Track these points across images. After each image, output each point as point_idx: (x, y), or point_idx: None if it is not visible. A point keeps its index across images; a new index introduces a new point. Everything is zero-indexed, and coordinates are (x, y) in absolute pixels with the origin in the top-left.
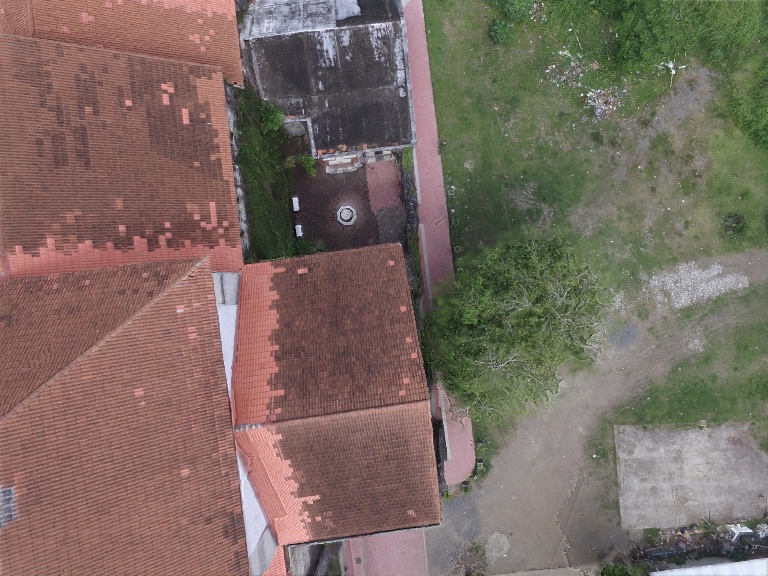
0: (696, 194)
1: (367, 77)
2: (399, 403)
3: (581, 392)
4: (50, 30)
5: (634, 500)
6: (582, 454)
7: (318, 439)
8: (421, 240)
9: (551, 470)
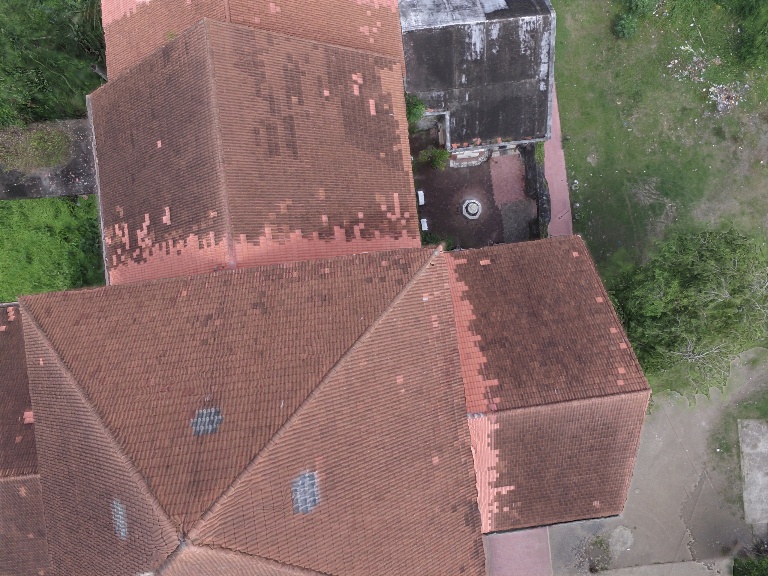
0: None
1: (510, 70)
2: (621, 392)
3: None
4: (244, 20)
5: (758, 494)
6: (705, 448)
7: (533, 428)
8: None
9: (674, 464)
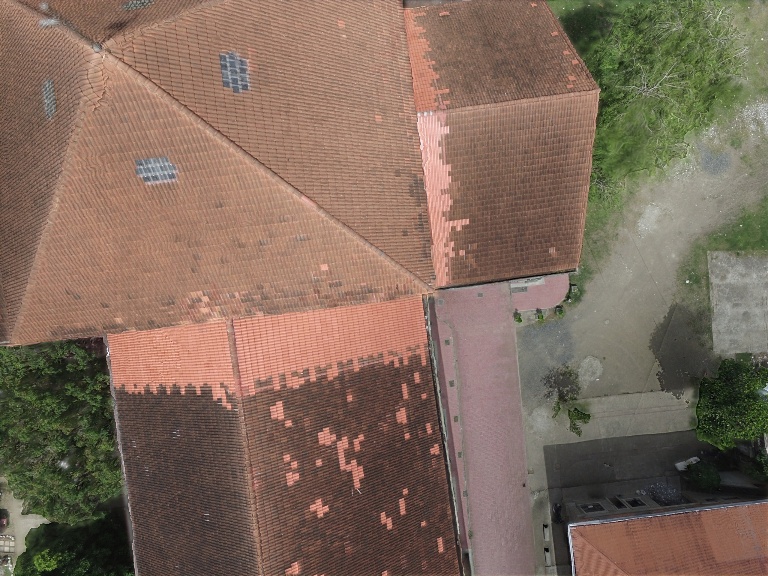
0: None
1: None
2: (570, 92)
3: (674, 219)
4: None
5: (727, 325)
6: (675, 280)
7: (483, 136)
8: None
9: (644, 295)
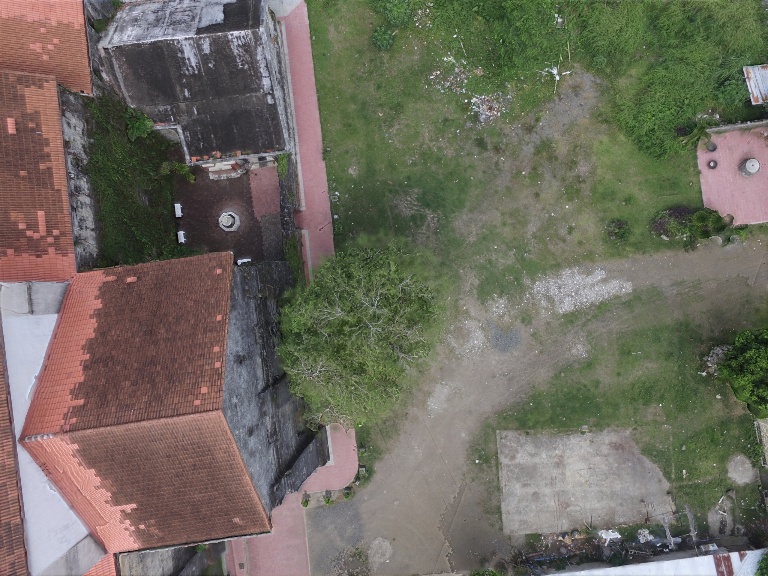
0: (580, 200)
1: (233, 84)
2: (191, 413)
3: (464, 397)
4: None
5: (516, 505)
6: (465, 459)
7: (117, 449)
8: (305, 246)
9: (434, 475)
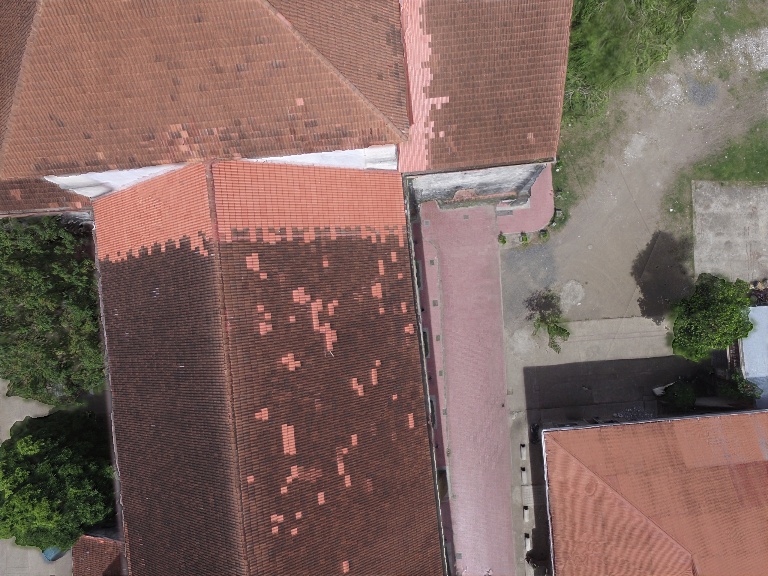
0: None
1: None
2: None
3: (660, 148)
4: None
5: (708, 254)
6: (659, 208)
7: (463, 5)
8: None
9: (628, 222)
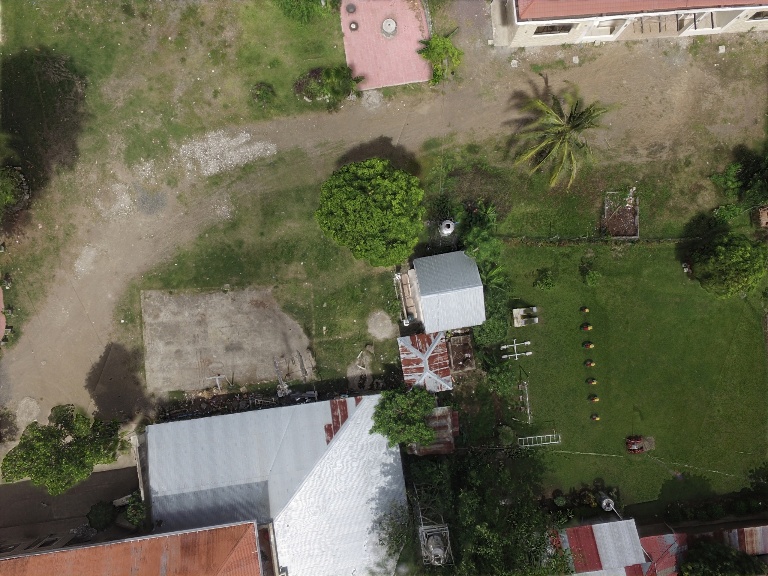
0: (225, 64)
1: None
2: None
3: (111, 259)
4: None
5: (159, 363)
6: (111, 320)
7: None
8: None
9: (80, 336)
